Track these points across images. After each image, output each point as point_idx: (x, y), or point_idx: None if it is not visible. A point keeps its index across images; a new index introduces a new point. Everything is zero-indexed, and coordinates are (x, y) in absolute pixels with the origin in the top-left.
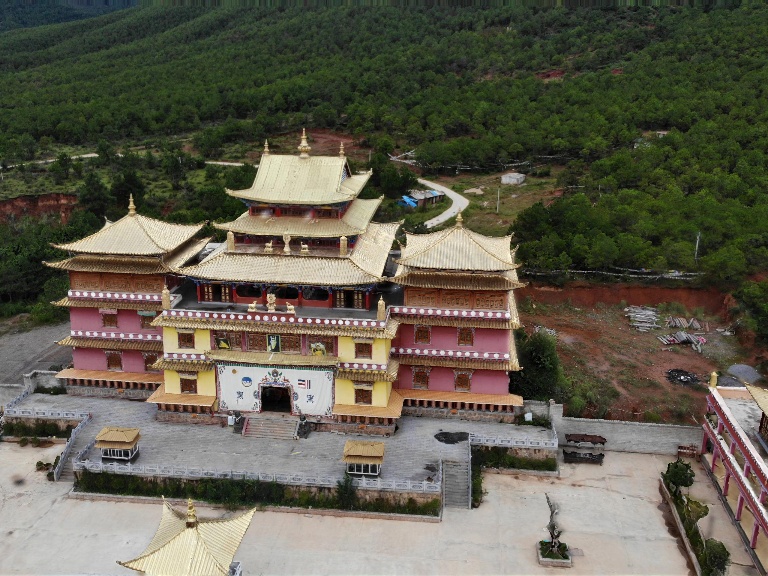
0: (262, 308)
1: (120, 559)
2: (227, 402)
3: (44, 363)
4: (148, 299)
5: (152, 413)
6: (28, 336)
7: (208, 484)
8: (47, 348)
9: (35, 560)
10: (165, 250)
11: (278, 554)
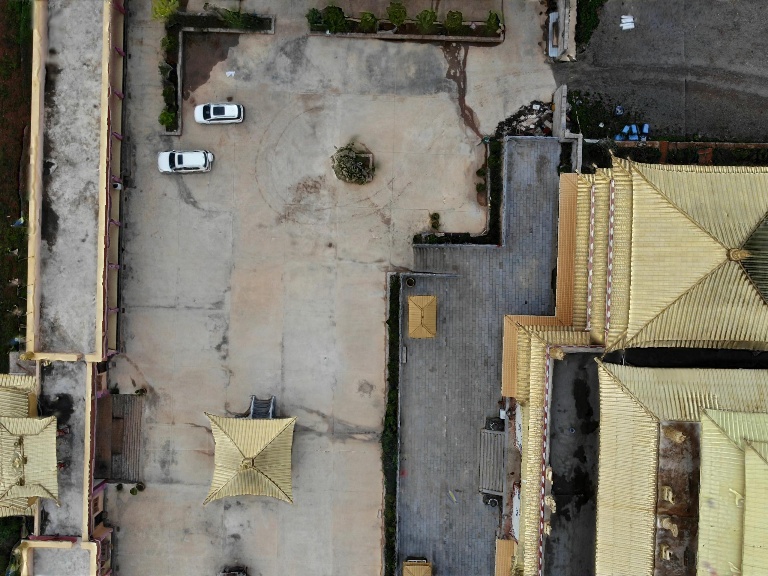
0: (594, 471)
1: (303, 361)
2: (518, 409)
3: (681, 91)
4: (608, 303)
5: (524, 310)
6: (767, 19)
7: (392, 417)
8: (727, 70)
9: (295, 288)
10: (627, 343)
11: (322, 497)
